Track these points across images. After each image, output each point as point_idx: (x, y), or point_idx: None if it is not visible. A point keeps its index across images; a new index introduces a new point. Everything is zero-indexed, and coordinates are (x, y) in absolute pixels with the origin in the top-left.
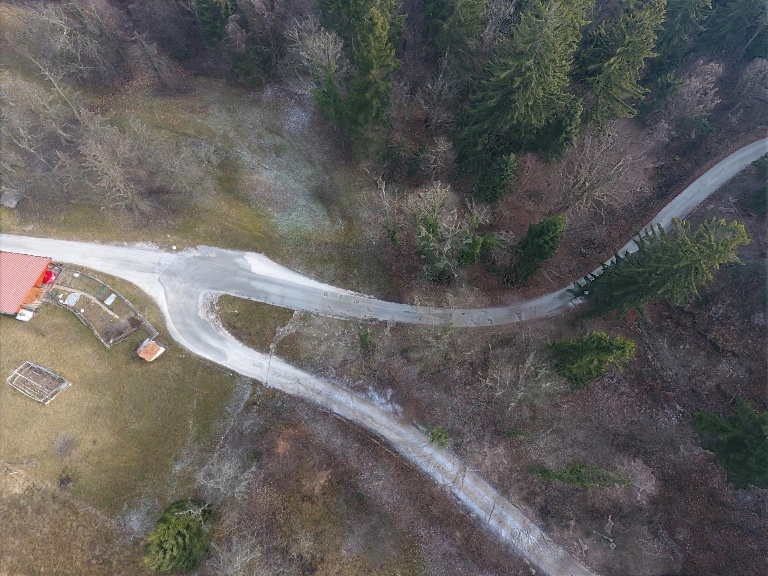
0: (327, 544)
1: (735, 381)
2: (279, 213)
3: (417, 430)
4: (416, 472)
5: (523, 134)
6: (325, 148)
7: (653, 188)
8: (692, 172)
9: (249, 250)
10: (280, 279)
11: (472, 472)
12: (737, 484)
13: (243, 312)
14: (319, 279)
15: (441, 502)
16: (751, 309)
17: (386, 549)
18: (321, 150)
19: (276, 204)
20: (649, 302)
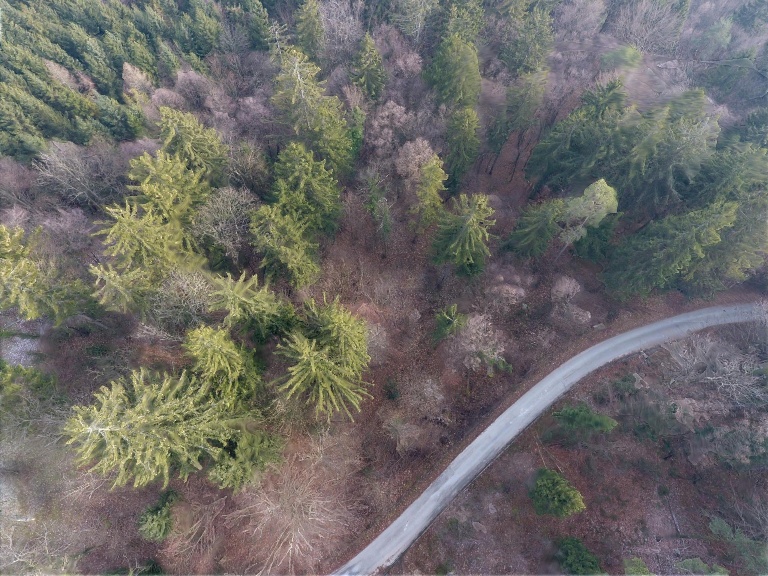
0: None
1: None
2: None
3: None
4: None
5: None
6: None
7: (456, 419)
8: (502, 400)
9: None
10: None
11: None
12: None
13: None
14: None
15: None
16: None
17: None
18: None
19: None
20: None
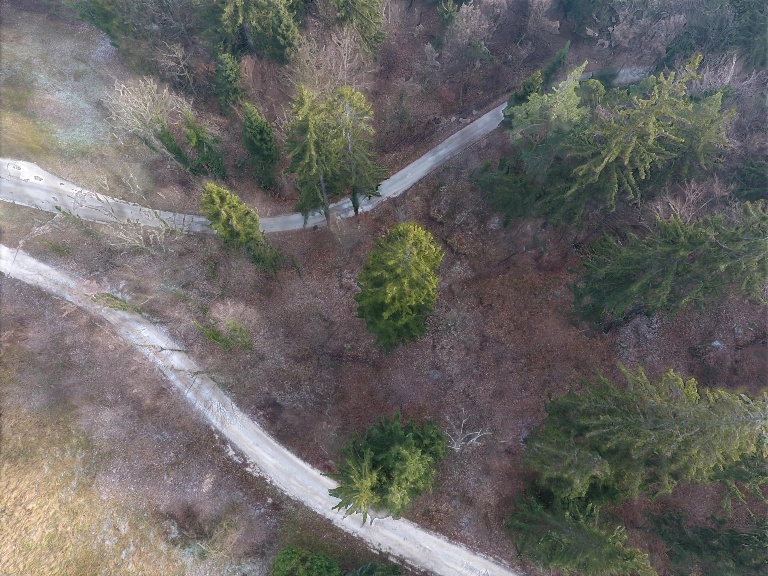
0: (9, 402)
1: (463, 280)
2: (63, 129)
3: (140, 315)
4: (129, 351)
5: (252, 40)
6: (125, 74)
7: None
8: (488, 103)
9: (21, 159)
10: (47, 186)
11: (181, 351)
12: (386, 347)
13: (4, 213)
14: (86, 187)
15: (143, 376)
16: (489, 216)
17: (66, 408)
18: (121, 76)
19: (62, 121)
20: (415, 217)
